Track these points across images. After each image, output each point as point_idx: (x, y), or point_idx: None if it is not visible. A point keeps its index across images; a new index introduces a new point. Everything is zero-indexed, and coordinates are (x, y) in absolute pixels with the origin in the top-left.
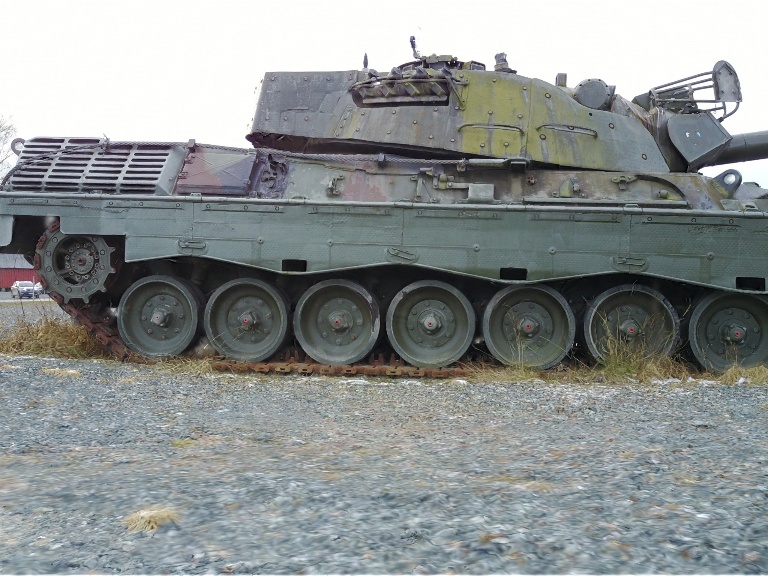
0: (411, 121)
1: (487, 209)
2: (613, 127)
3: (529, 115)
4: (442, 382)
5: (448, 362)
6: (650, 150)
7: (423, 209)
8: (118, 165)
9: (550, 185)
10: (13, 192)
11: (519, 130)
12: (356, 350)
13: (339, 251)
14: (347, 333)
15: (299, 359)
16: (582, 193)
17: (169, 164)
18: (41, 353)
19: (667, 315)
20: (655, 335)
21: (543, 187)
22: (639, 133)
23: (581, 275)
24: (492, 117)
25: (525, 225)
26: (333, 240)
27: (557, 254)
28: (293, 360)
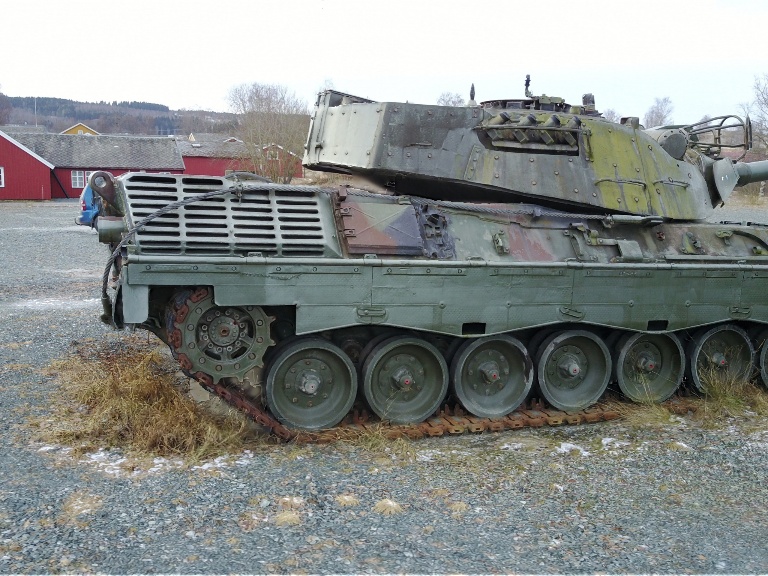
0: (552, 172)
1: (643, 268)
2: (691, 177)
3: (643, 168)
4: (626, 435)
5: (590, 404)
6: (707, 195)
7: (591, 269)
8: (265, 217)
9: (674, 240)
10: (147, 256)
11: (642, 185)
12: (509, 400)
13: (517, 312)
14: (494, 383)
15: (450, 412)
16: (703, 249)
17: (324, 216)
18: (217, 452)
19: (746, 348)
20: (734, 363)
21: (670, 242)
22: (702, 180)
23: (707, 323)
24: (617, 170)
25: (670, 282)
26: (511, 301)
27: (691, 306)
28: (444, 414)
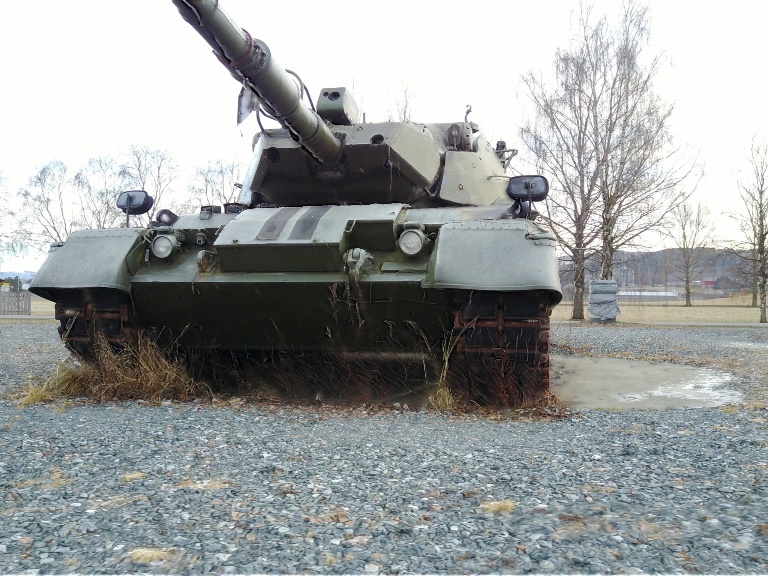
0: None
1: None
2: None
3: None
4: None
5: None
6: None
7: None
8: None
9: None
10: None
11: None
12: None
13: None
14: None
15: None
16: None
17: None
18: None
19: None
20: None
21: None
22: None
23: None
24: None
25: None
26: None
27: None
28: None
